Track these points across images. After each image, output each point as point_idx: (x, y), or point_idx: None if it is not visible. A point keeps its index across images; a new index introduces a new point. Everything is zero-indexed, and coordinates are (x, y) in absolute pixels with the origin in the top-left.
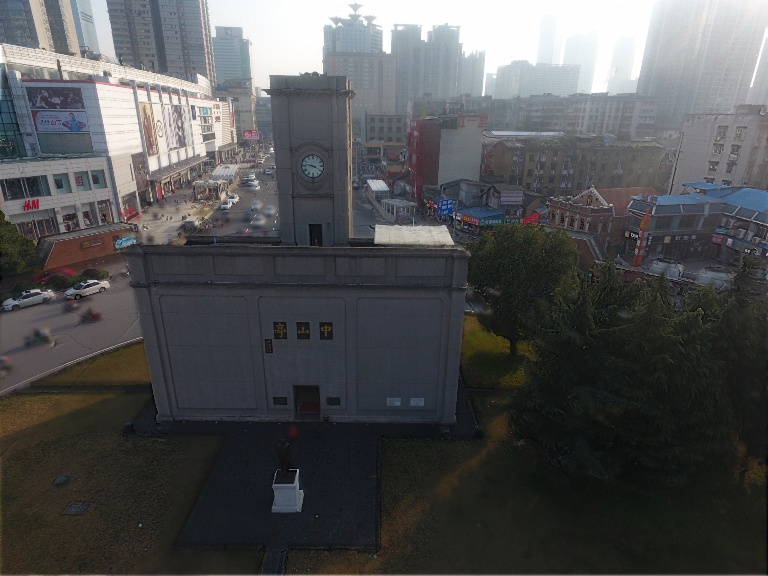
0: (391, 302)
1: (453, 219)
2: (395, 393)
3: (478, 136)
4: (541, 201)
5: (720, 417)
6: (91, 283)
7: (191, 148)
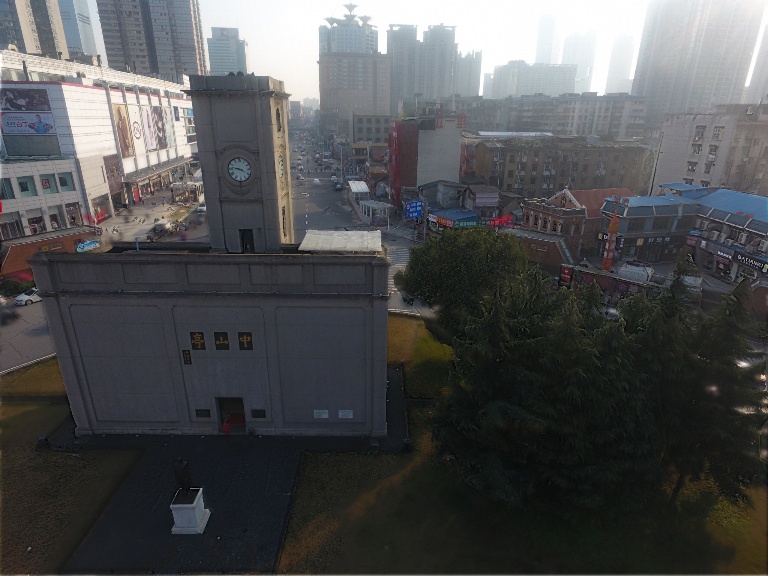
0: (311, 311)
1: (429, 221)
2: (322, 405)
3: (457, 137)
4: (518, 202)
5: (641, 433)
6: None
7: (173, 149)
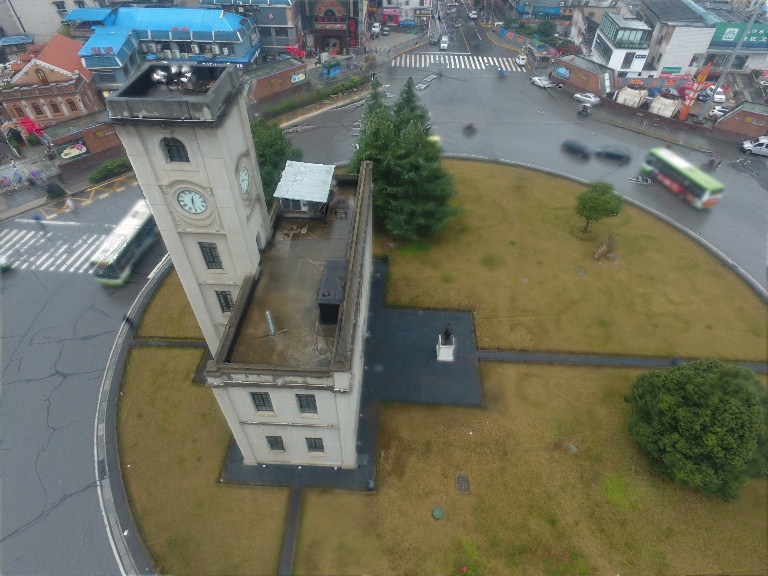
0: None
1: None
2: None
3: None
4: None
5: None
6: None
7: None
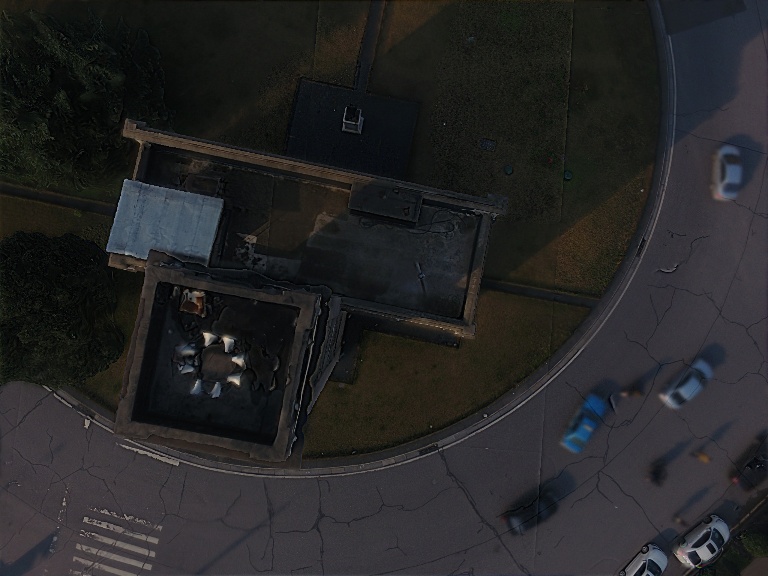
0: None
1: None
2: None
3: None
4: None
5: None
6: None
7: None
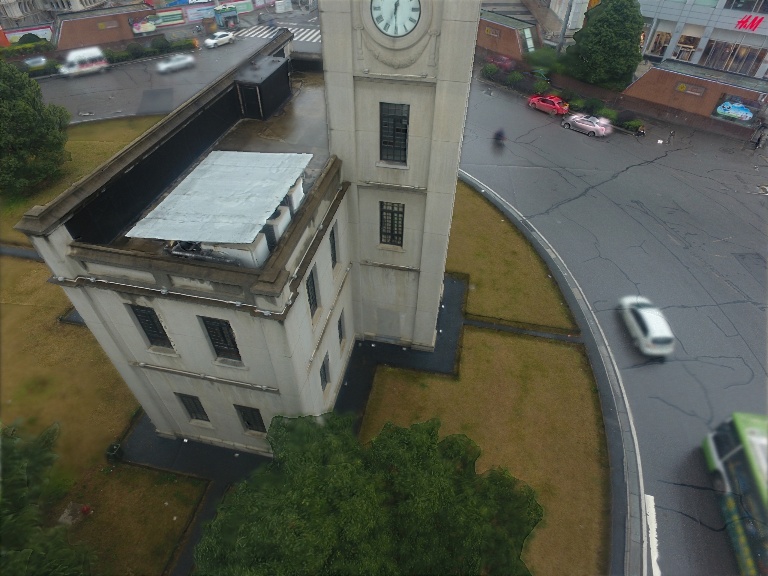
0: None
1: None
2: None
3: None
4: None
5: None
6: (587, 120)
7: None
